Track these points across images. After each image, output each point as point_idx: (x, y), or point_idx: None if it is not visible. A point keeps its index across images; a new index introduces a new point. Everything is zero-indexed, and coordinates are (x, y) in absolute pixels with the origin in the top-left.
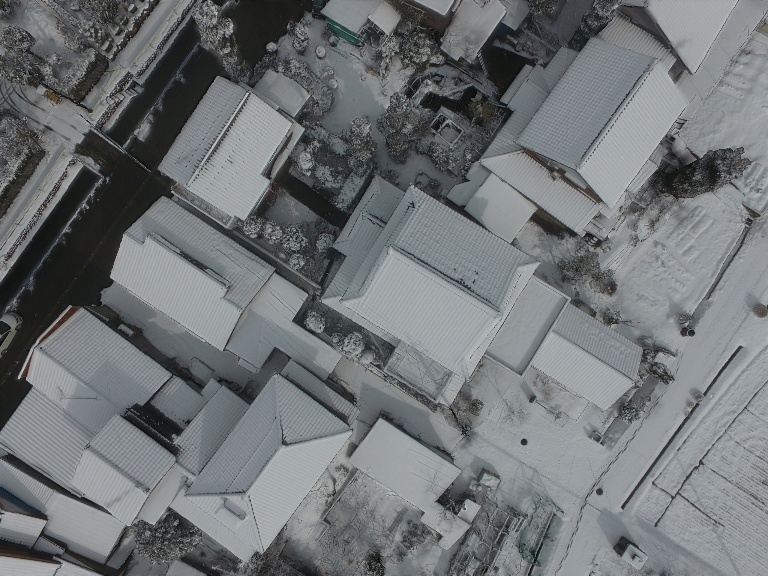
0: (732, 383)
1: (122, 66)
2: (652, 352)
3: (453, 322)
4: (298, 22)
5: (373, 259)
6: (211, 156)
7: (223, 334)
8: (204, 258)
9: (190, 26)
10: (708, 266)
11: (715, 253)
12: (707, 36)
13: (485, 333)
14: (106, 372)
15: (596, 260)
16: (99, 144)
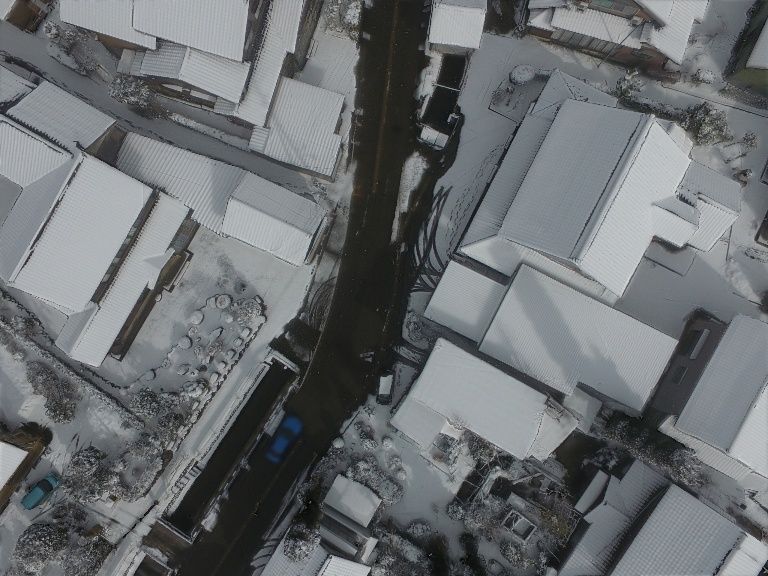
0: None
1: (187, 458)
2: None
3: None
4: (362, 405)
5: None
6: None
7: None
8: None
9: (251, 401)
10: None
11: None
12: None
13: None
14: None
15: None
16: (166, 535)
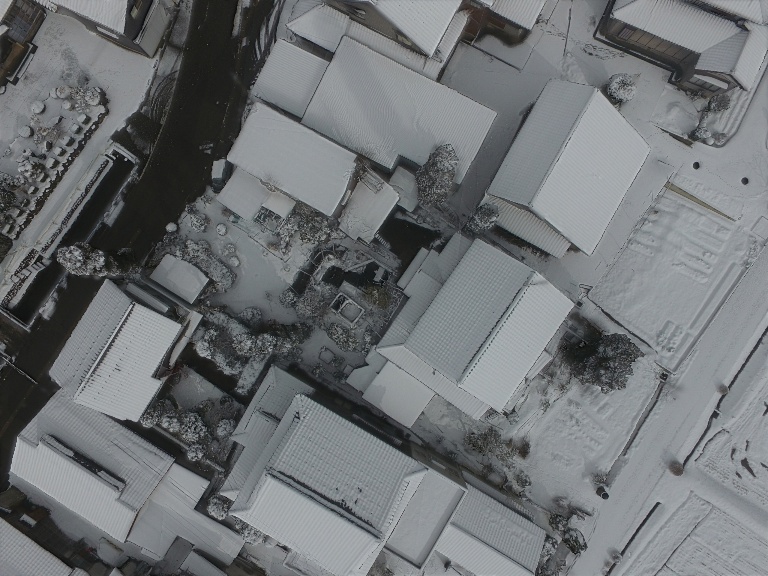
0: (651, 540)
1: (25, 245)
2: (564, 519)
3: (337, 540)
4: (200, 197)
5: (260, 469)
6: (97, 367)
7: (122, 529)
8: (100, 455)
9: (96, 198)
10: (623, 423)
11: (630, 410)
12: (602, 218)
13: (369, 552)
14: (3, 575)
15: (499, 440)
16: (5, 323)
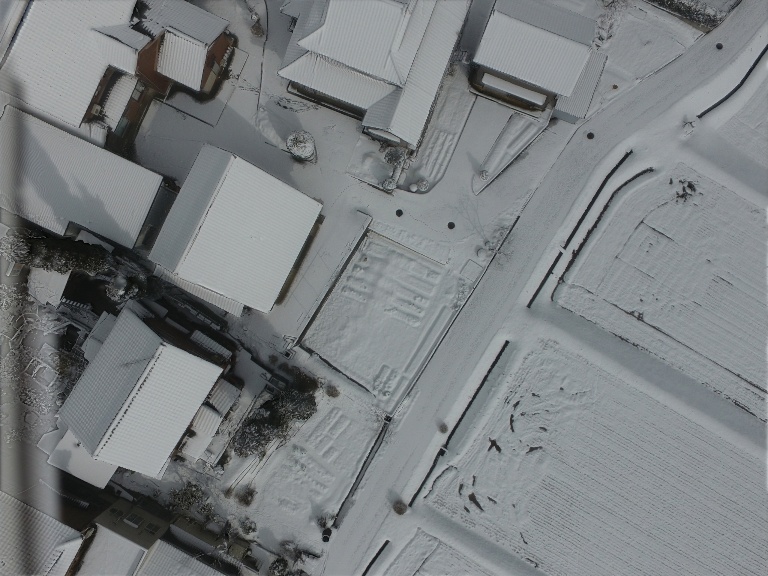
0: None
1: None
2: (281, 565)
3: None
4: None
5: None
6: None
7: None
8: None
9: None
10: (348, 466)
11: (354, 453)
12: (274, 277)
13: None
14: None
15: (194, 495)
16: None
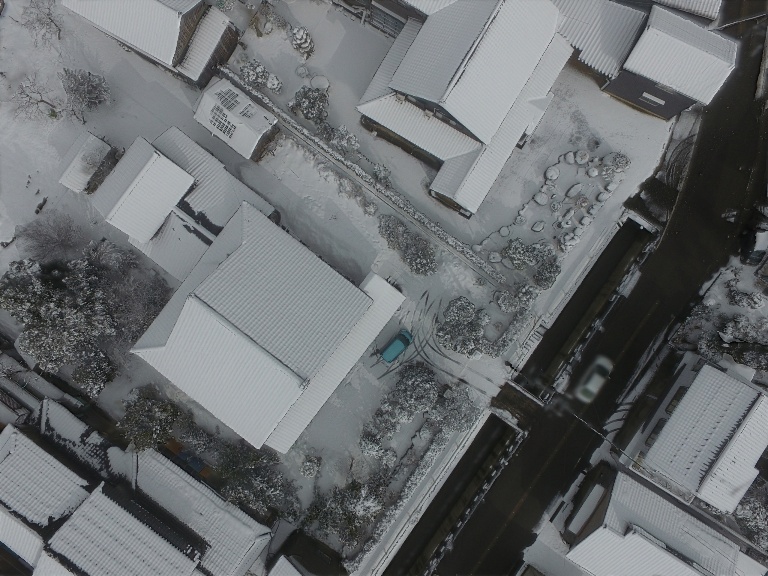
0: None
1: None
2: None
3: None
4: (723, 267)
5: None
6: None
7: None
8: (678, 545)
9: (595, 265)
10: None
11: None
12: None
13: None
14: None
15: None
16: (516, 397)
